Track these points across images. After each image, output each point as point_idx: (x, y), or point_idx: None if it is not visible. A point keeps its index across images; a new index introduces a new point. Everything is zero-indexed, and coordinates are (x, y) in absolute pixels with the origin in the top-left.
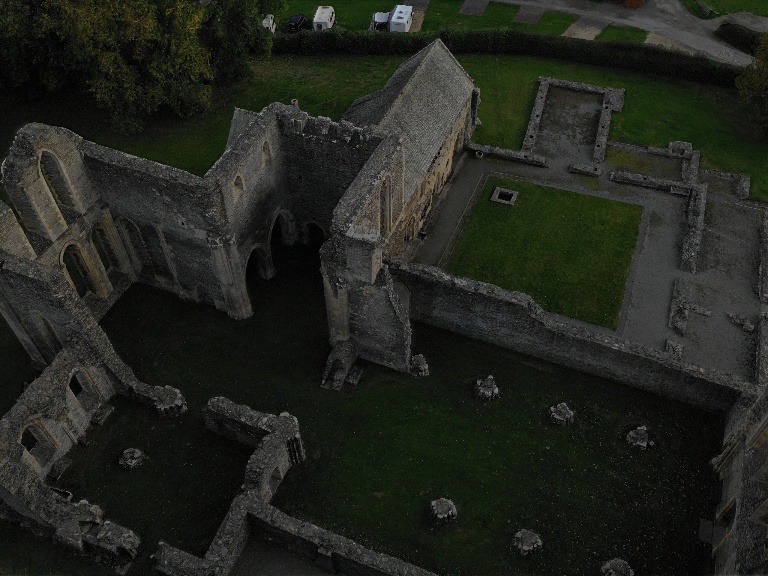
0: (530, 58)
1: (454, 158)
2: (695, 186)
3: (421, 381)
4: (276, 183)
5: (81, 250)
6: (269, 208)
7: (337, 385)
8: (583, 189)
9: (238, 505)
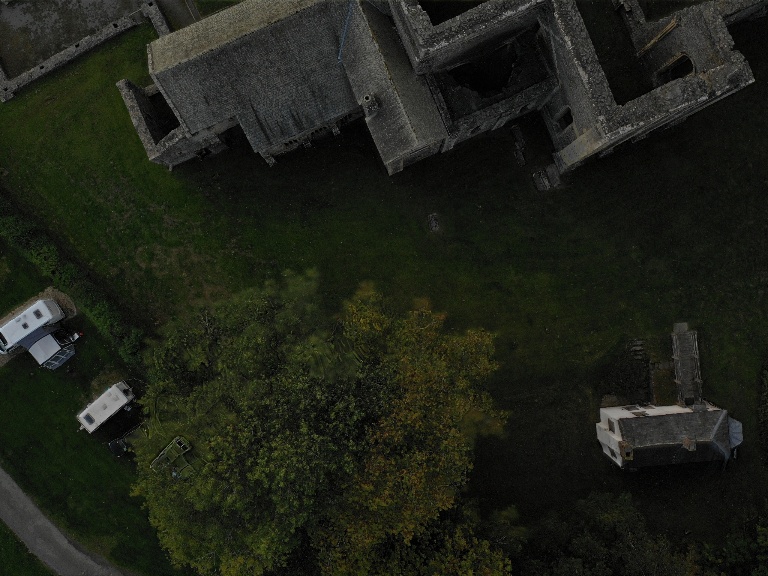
0: None
1: None
2: None
3: None
4: None
5: None
6: None
7: None
8: None
9: None
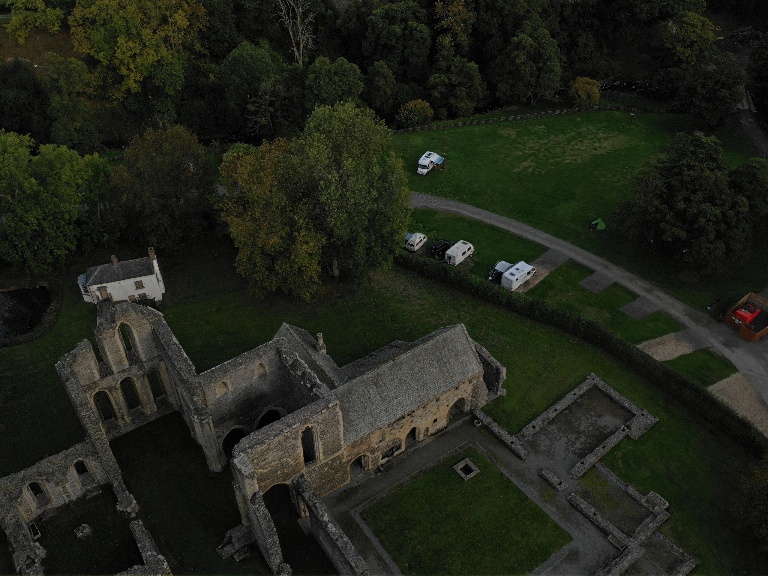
0: (601, 352)
1: (457, 416)
2: (631, 545)
3: None
4: (270, 390)
5: (136, 382)
6: (259, 404)
7: (224, 554)
8: (536, 496)
9: None
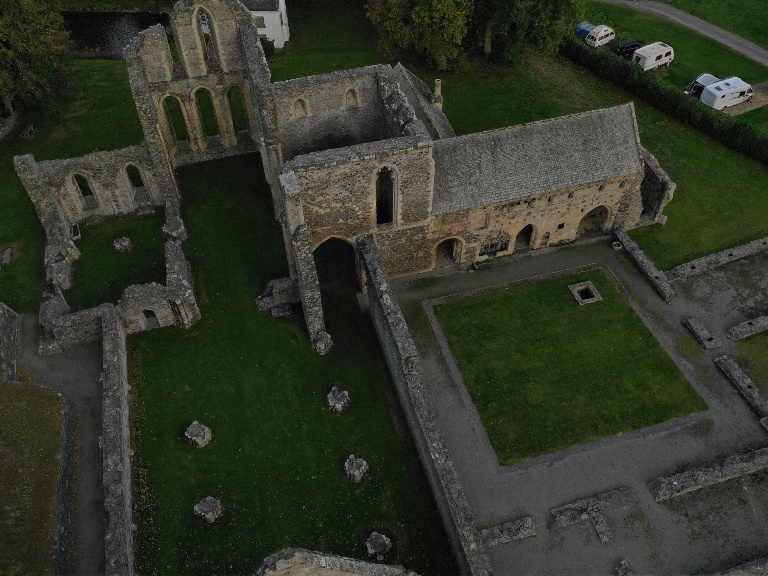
0: None
1: (592, 233)
2: None
3: (311, 354)
4: (361, 133)
5: (214, 98)
6: None
7: (261, 306)
8: (671, 345)
9: (103, 307)
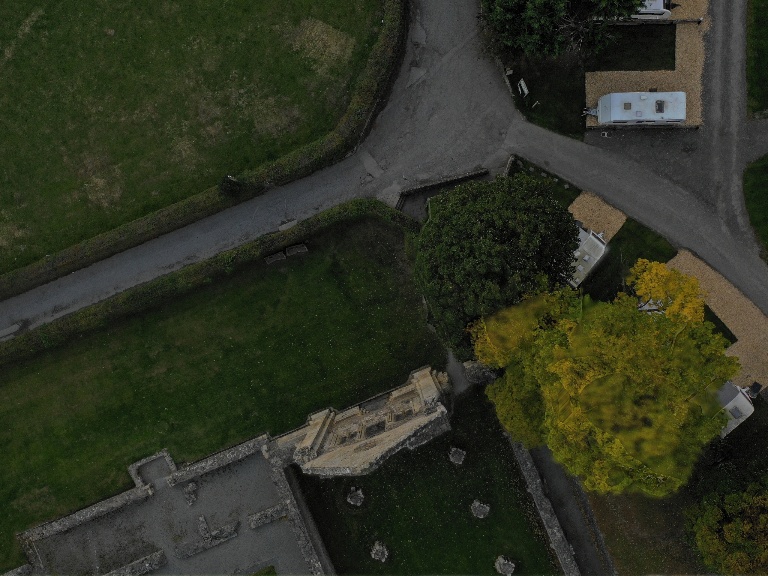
0: None
1: None
2: None
3: None
4: None
5: None
6: None
7: None
8: None
9: None
